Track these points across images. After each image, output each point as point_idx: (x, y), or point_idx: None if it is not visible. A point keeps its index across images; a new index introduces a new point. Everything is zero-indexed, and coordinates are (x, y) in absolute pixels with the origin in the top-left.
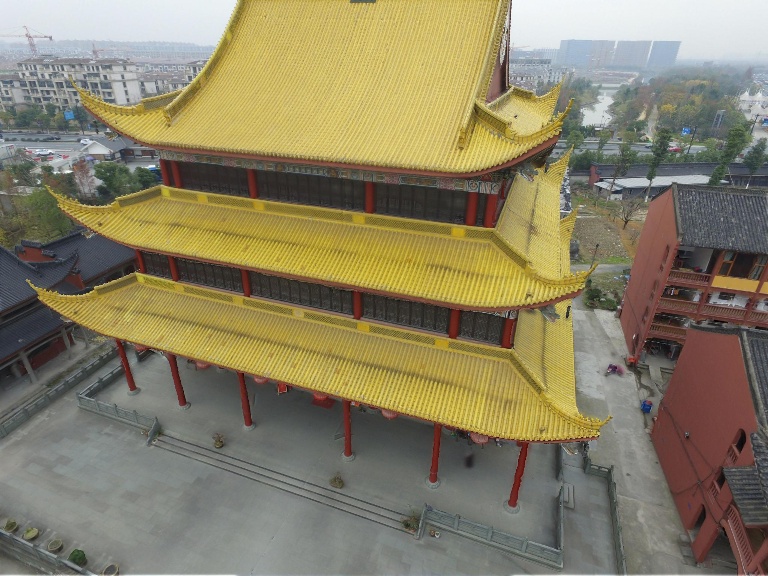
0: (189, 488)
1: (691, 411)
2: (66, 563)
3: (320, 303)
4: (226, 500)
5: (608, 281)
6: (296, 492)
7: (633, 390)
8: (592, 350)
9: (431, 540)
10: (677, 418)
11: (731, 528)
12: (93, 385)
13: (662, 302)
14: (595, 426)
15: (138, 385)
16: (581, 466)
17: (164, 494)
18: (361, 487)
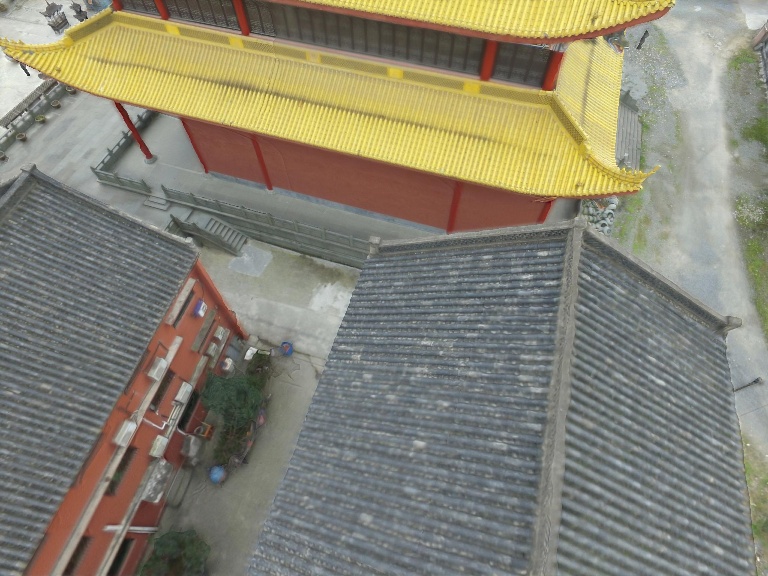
0: None
1: None
2: None
3: None
4: None
5: None
6: None
7: None
8: None
9: None
10: None
11: None
12: None
13: None
14: None
15: None
16: None
17: None
18: None
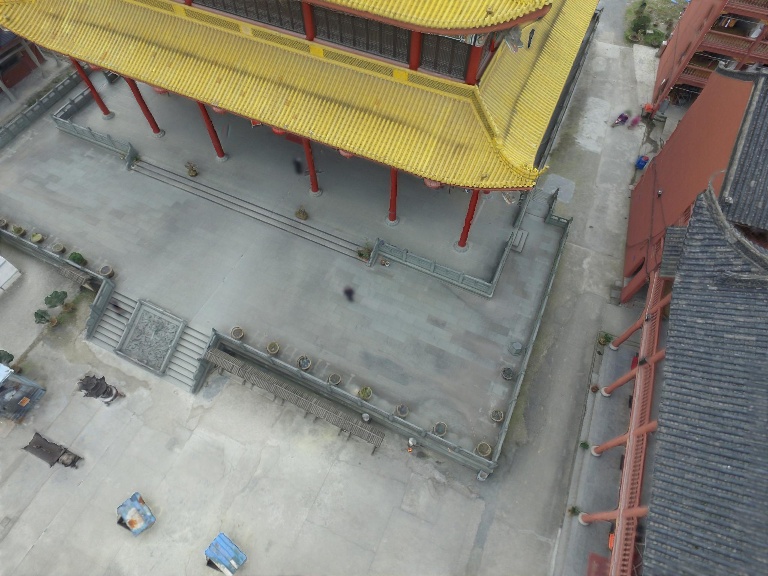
0: (168, 210)
1: (674, 169)
2: (67, 262)
3: (268, 17)
4: (202, 223)
5: (669, 6)
6: (264, 220)
7: (636, 144)
8: (610, 96)
9: (381, 268)
10: (660, 176)
11: (655, 278)
12: (65, 106)
13: (709, 37)
14: (532, 176)
15: (112, 109)
16: (543, 216)
17: (146, 214)
18: (324, 220)
